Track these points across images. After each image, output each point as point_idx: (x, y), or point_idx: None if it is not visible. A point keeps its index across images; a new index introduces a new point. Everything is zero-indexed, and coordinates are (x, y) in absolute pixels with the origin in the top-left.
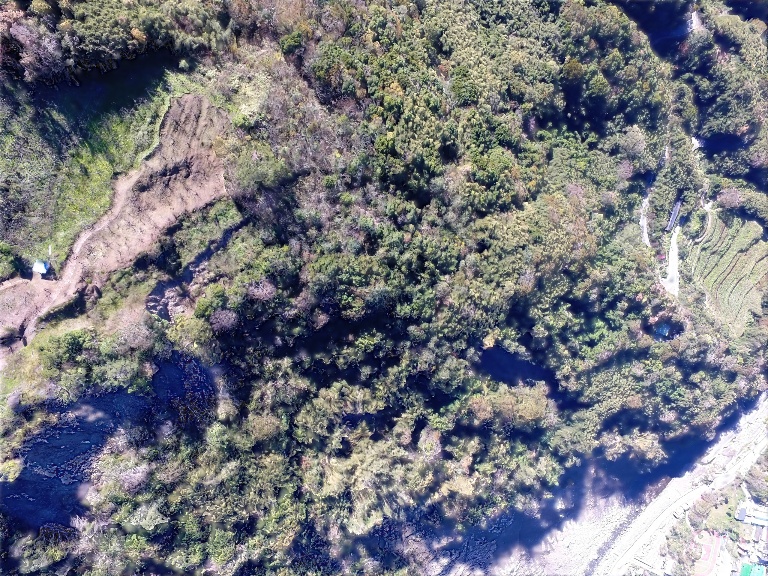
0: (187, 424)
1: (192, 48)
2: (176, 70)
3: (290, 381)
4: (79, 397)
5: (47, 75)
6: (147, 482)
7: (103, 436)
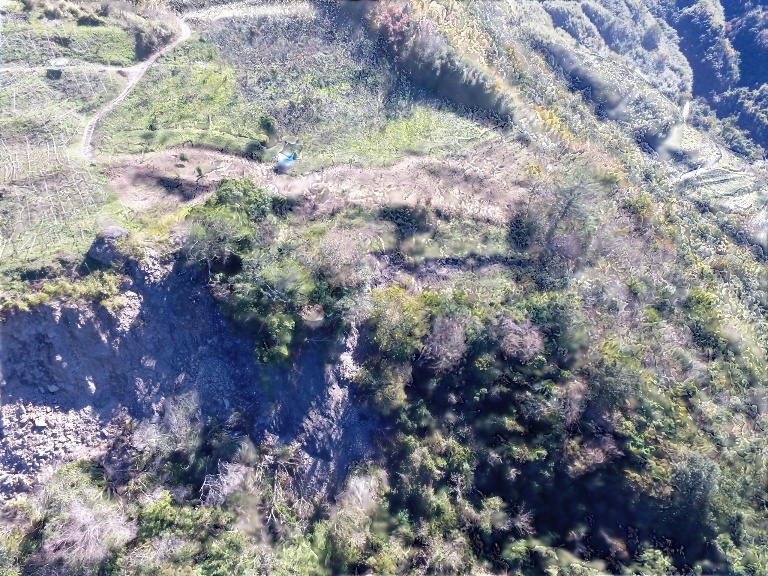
0: (256, 495)
1: (534, 121)
2: (514, 123)
3: (473, 563)
4: (175, 290)
5: (427, 47)
6: (87, 559)
7: (122, 399)
